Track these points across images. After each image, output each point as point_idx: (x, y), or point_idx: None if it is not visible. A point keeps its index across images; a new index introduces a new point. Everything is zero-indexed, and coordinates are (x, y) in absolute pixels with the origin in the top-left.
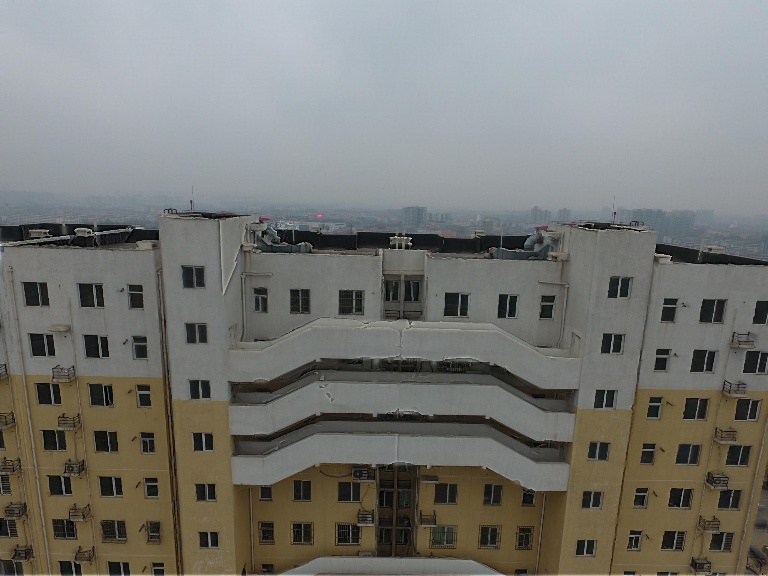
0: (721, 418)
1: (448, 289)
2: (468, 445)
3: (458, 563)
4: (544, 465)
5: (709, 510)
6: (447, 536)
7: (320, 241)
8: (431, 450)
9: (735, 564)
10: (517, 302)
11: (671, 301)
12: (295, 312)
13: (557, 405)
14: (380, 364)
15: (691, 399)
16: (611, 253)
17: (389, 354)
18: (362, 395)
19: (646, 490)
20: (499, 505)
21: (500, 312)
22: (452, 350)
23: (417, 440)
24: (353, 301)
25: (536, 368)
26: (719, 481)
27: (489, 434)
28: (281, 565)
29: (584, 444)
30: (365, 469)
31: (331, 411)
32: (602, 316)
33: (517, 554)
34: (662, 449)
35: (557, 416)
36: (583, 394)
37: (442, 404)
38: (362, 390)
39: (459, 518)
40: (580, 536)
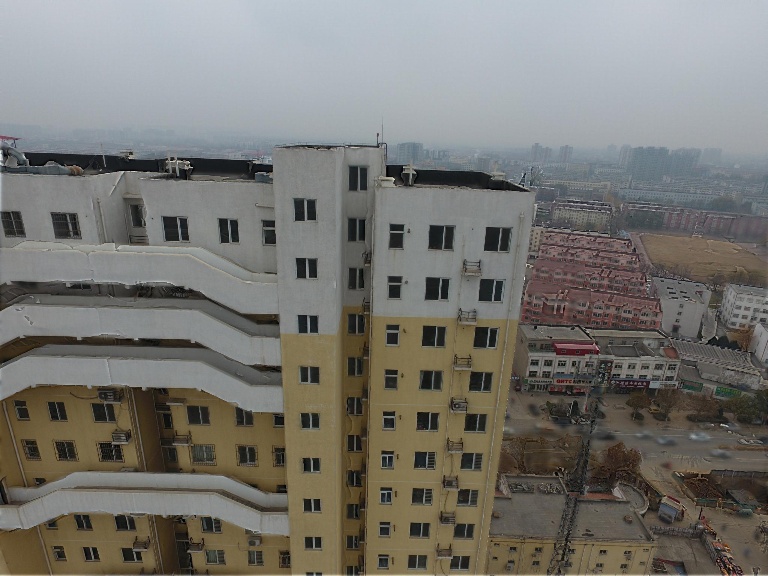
0: (460, 345)
1: (163, 212)
2: (179, 368)
3: (209, 478)
4: (257, 388)
5: (456, 433)
6: (207, 454)
7: (123, 166)
8: (143, 373)
9: (485, 482)
10: (238, 227)
11: (398, 227)
12: (10, 235)
13: (277, 331)
14: (110, 289)
15: (428, 327)
16: (289, 173)
17: (79, 277)
18: (61, 318)
19: (394, 414)
20: (251, 426)
21: (223, 237)
22: (143, 274)
23: (127, 363)
24: (69, 224)
25: (232, 293)
26: (459, 405)
27: (204, 358)
28: (49, 479)
29: (293, 368)
30: (109, 391)
31: (34, 334)
32: (290, 240)
33: (275, 471)
34: (402, 375)
35: (262, 341)
36: (284, 319)
37: (144, 328)
38: (60, 313)
39: (215, 438)
40: (303, 454)
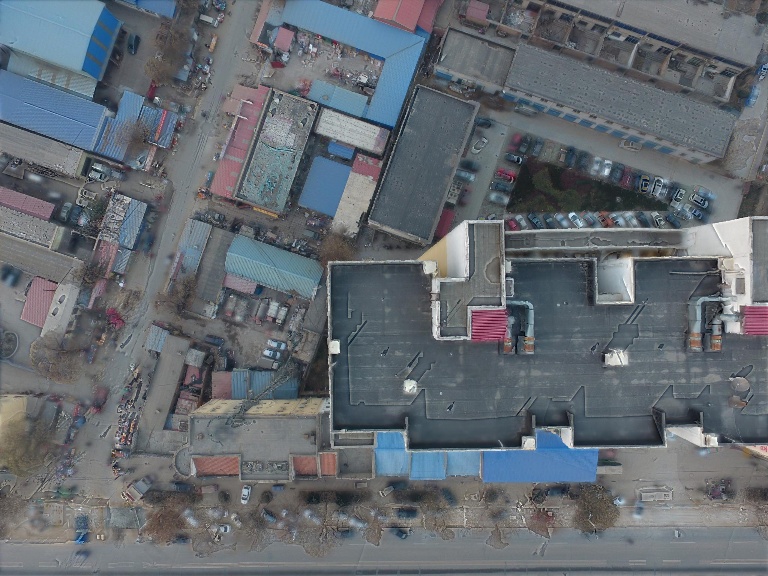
0: None
1: None
2: None
3: None
4: None
5: None
6: None
7: (695, 415)
8: None
9: None
10: None
11: None
12: None
13: None
14: None
15: None
16: None
17: None
18: None
19: None
20: None
21: None
22: None
23: None
24: None
25: None
26: None
27: None
28: None
29: None
30: None
31: None
32: None
33: None
34: None
35: None
36: None
37: None
38: None
39: None
40: None
